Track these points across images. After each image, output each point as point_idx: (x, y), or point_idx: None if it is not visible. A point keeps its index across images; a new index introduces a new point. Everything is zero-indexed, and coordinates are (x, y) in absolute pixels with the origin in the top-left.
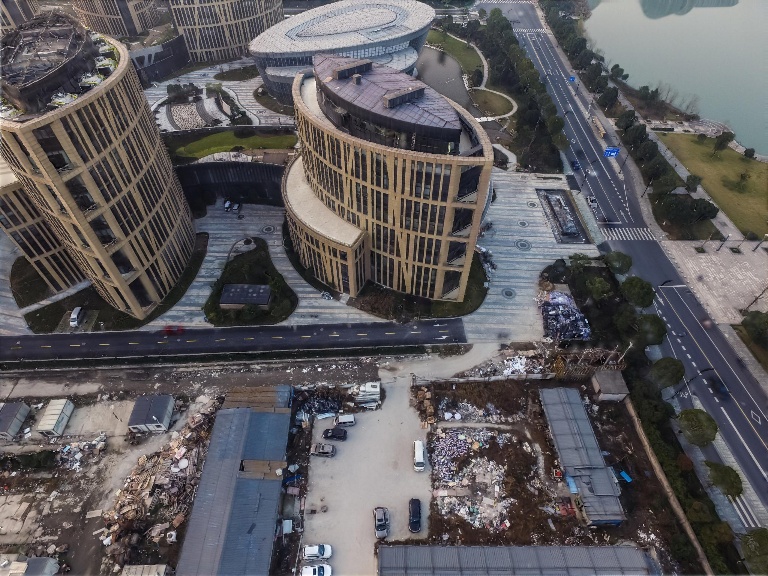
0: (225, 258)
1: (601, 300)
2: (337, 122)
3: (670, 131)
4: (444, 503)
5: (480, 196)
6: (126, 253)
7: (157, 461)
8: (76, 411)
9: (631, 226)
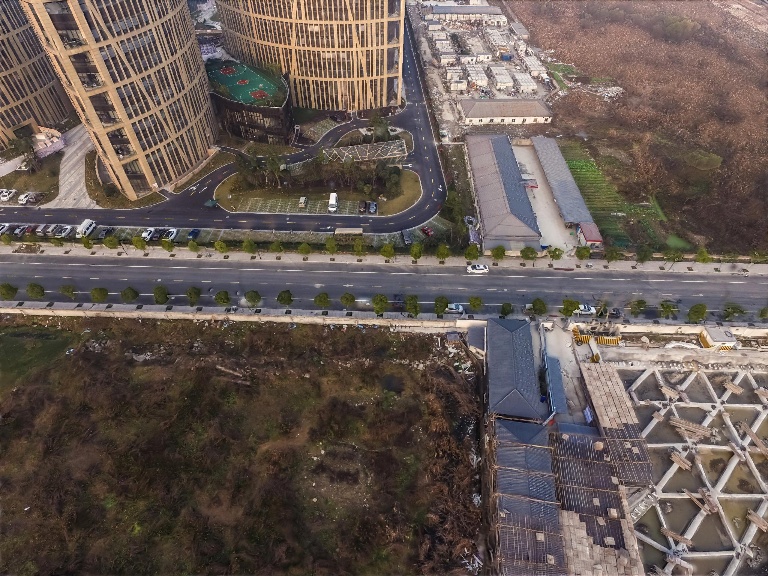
0: None
1: None
2: None
3: None
4: None
5: None
6: None
7: None
8: None
9: None
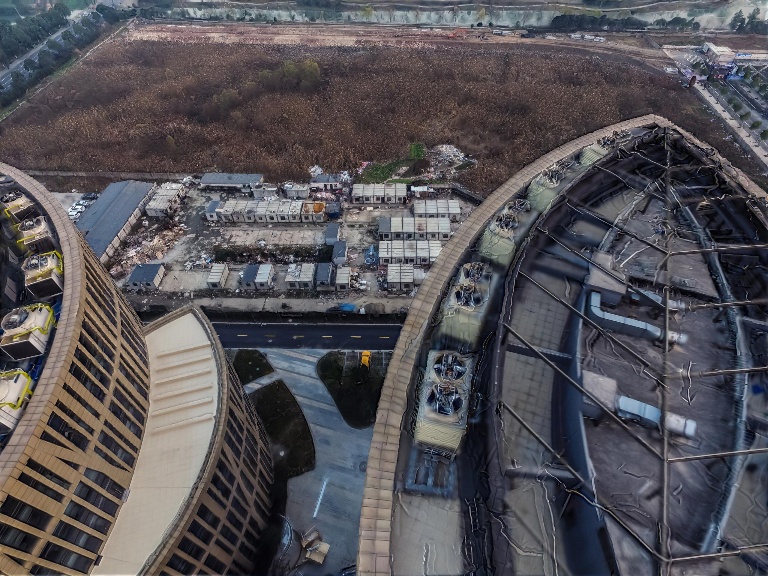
0: None
1: None
2: None
3: None
4: None
5: None
6: None
7: None
8: None
9: None
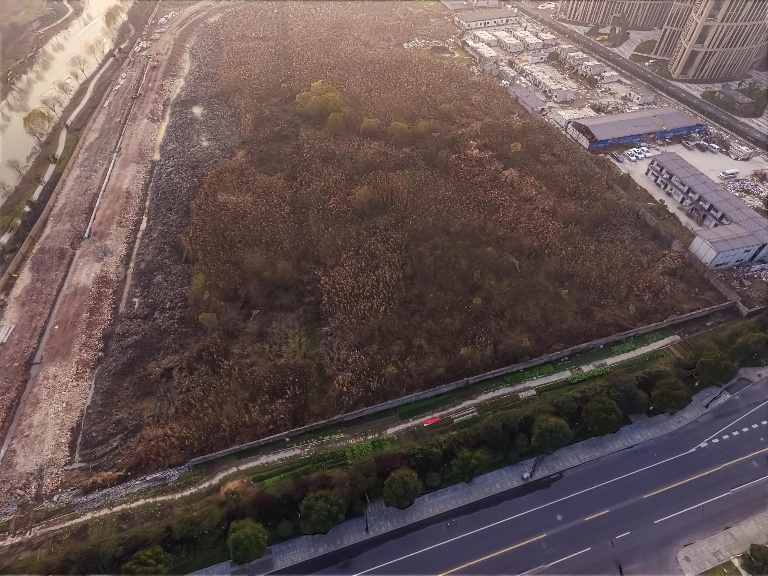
0: (746, 87)
1: None
2: None
3: None
4: None
5: None
6: (710, 32)
7: (625, 105)
8: (616, 83)
9: None
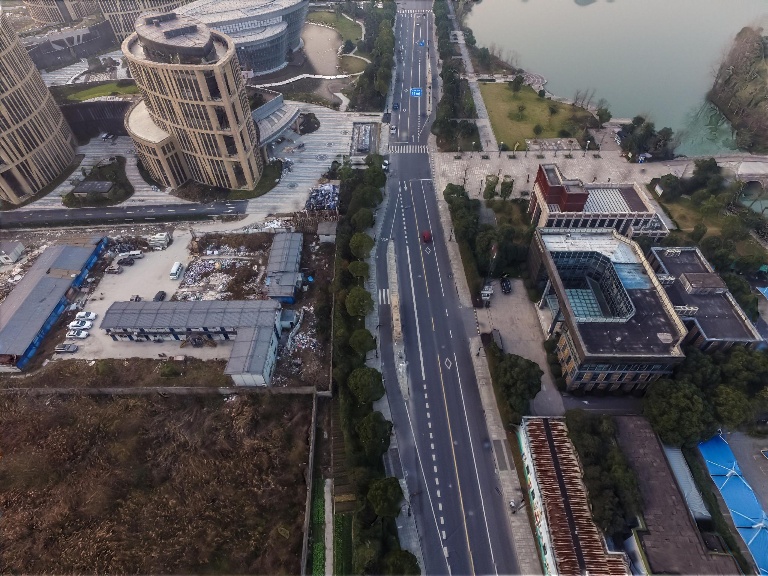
0: None
1: (348, 183)
2: (146, 55)
3: (492, 81)
4: (182, 294)
5: (222, 95)
6: None
7: (0, 276)
8: None
9: (414, 144)
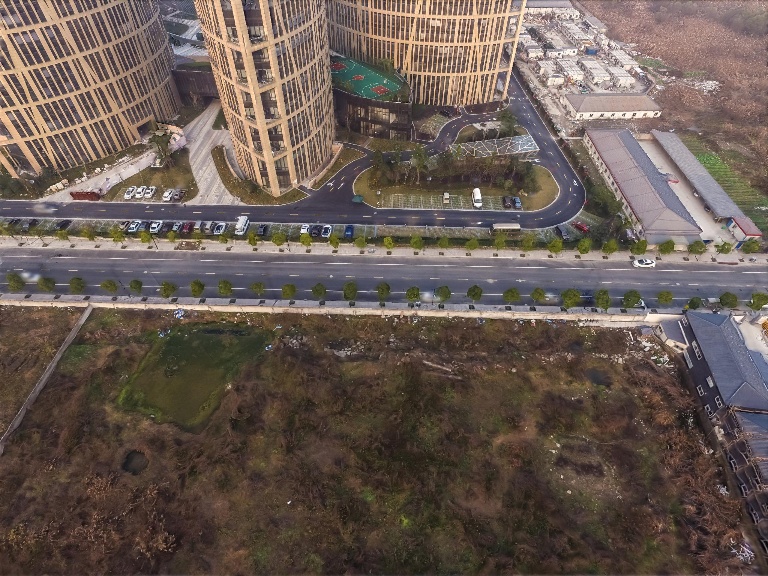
0: None
1: None
2: None
3: None
4: None
5: None
6: None
7: None
8: None
9: None
